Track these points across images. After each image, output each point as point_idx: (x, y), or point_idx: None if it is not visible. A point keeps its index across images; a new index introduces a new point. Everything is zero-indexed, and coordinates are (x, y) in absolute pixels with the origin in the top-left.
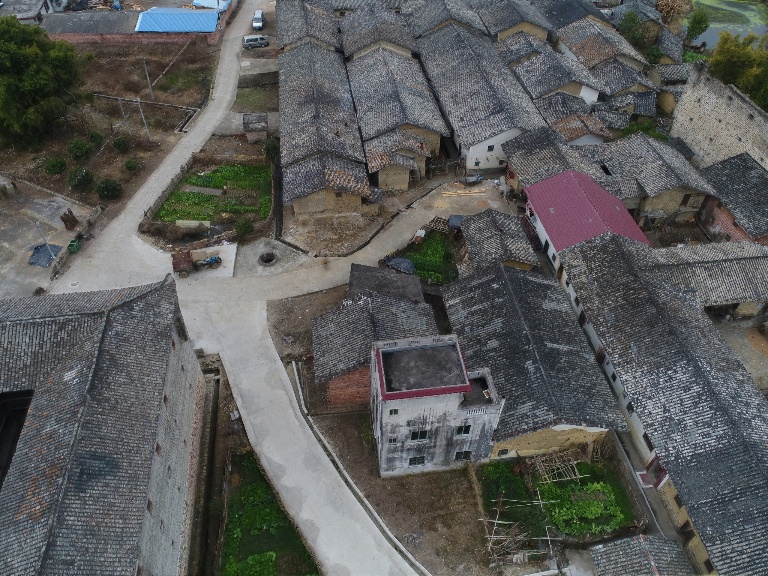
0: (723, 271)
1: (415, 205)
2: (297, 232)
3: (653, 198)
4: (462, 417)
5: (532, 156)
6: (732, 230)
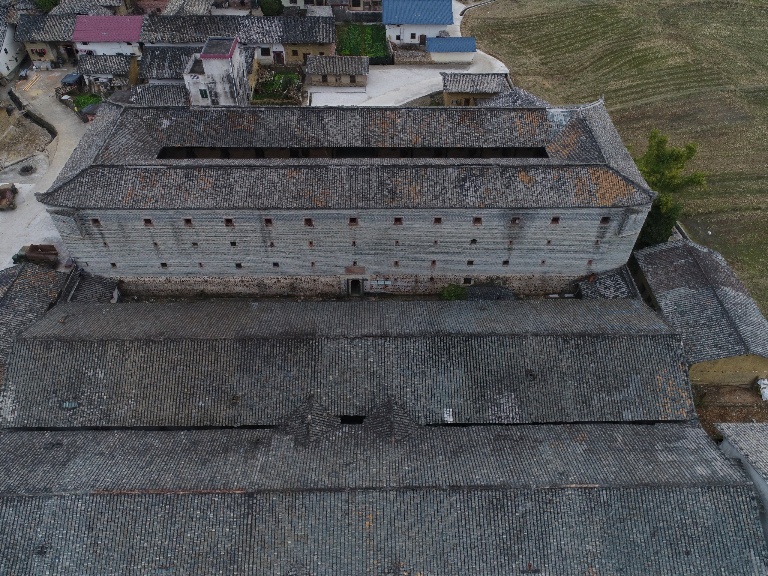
0: (191, 3)
1: (25, 103)
2: (2, 160)
3: (118, 10)
4: (241, 63)
5: (45, 28)
6: (157, 4)
